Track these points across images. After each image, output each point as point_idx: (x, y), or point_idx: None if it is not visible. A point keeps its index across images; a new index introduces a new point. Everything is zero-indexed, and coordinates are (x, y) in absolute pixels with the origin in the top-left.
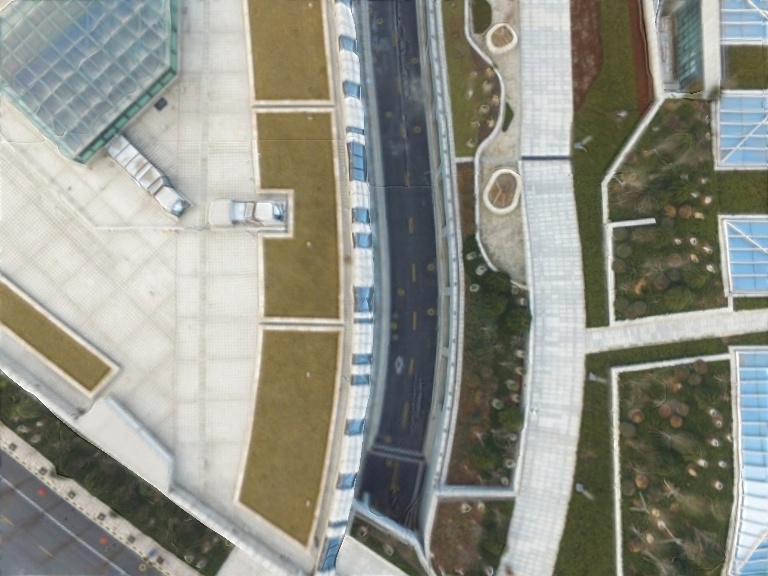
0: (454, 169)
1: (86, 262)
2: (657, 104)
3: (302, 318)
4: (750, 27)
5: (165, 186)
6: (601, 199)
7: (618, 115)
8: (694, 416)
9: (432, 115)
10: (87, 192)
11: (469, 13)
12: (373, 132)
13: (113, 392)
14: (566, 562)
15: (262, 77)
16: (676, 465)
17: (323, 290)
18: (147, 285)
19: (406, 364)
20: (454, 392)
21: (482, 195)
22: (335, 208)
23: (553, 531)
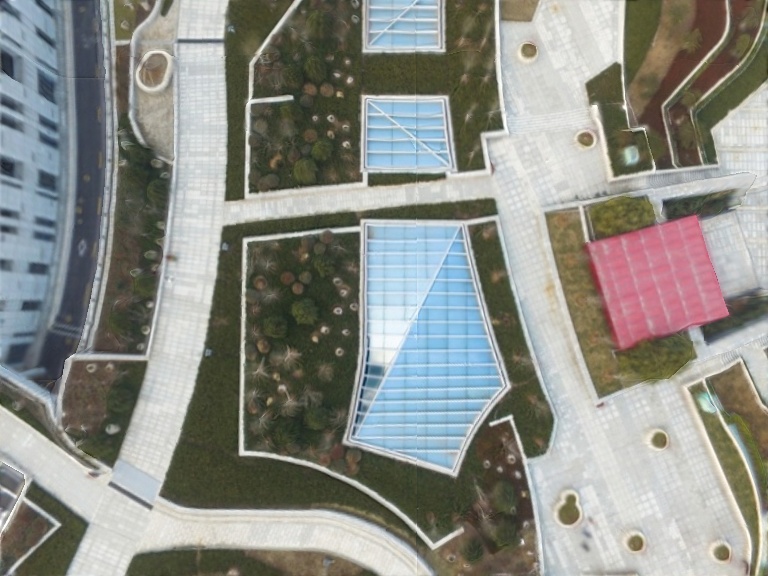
0: (114, 52)
1: None
2: None
3: None
4: None
5: None
6: (248, 79)
7: None
8: (318, 284)
9: None
10: None
11: None
12: (66, 26)
13: None
14: (192, 424)
15: None
16: (291, 329)
17: None
18: None
19: (89, 247)
20: (104, 264)
21: (135, 75)
22: None
23: (183, 395)
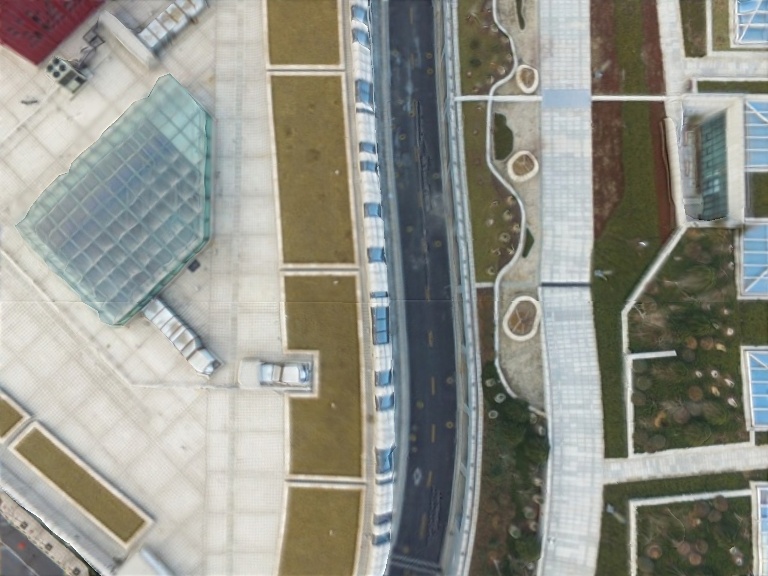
0: (474, 294)
1: (123, 416)
2: (679, 233)
3: (326, 476)
4: None
5: (197, 350)
6: (621, 328)
7: (639, 244)
8: (713, 553)
9: (453, 233)
10: (124, 350)
11: (491, 140)
12: (395, 246)
13: (146, 542)
14: None
15: (290, 241)
16: None
17: (346, 449)
18: (179, 440)
19: (424, 476)
20: (472, 516)
21: (502, 322)
22: (359, 369)
23: None
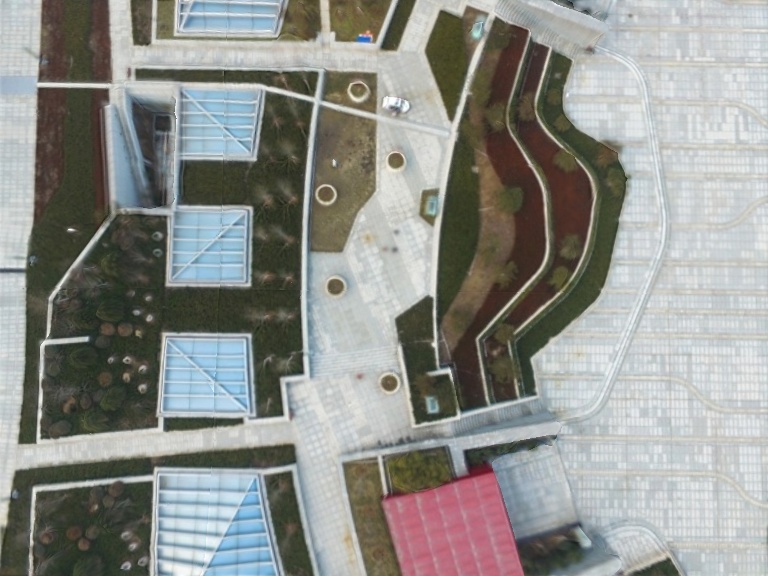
0: None
1: None
2: (108, 220)
3: None
4: (211, 142)
5: None
6: (46, 314)
7: (66, 231)
8: (106, 538)
9: None
10: None
11: None
12: None
13: None
14: None
15: None
16: None
17: None
18: None
19: None
20: None
21: None
22: None
23: None
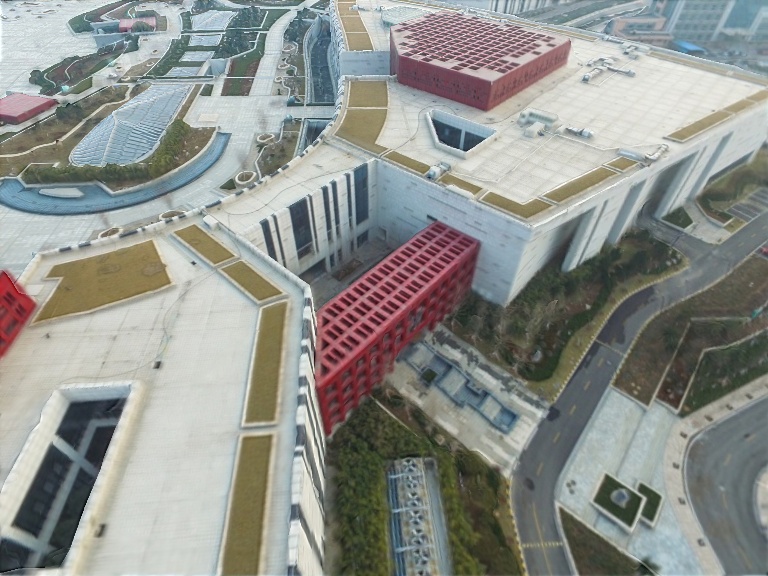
0: None
1: None
2: (231, 58)
3: None
4: None
5: (380, 7)
6: None
7: None
8: None
9: None
10: None
11: None
12: None
13: None
14: None
15: None
16: None
17: None
18: (385, 5)
19: None
20: None
21: None
22: None
23: None
